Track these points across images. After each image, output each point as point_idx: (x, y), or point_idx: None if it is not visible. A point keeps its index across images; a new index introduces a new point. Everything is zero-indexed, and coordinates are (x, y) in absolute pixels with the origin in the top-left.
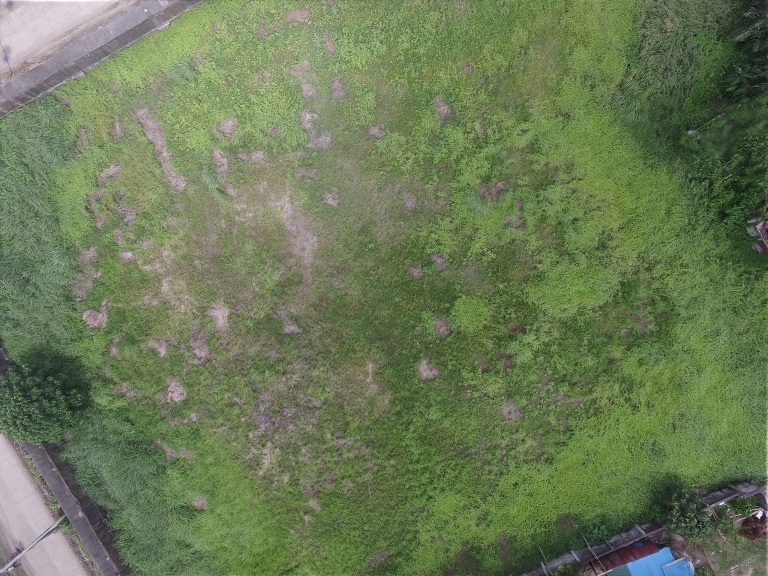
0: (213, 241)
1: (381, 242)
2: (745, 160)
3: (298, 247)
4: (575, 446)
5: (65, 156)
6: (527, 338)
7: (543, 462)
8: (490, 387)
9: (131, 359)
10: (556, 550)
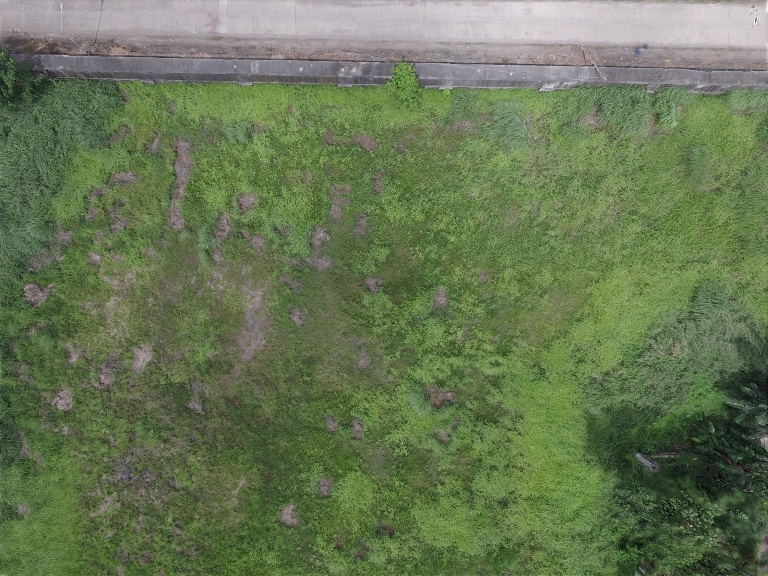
0: (176, 290)
1: (318, 380)
2: (656, 532)
3: (245, 340)
4: None
5: (93, 144)
6: (390, 543)
7: None
8: (333, 565)
9: (43, 348)
10: None
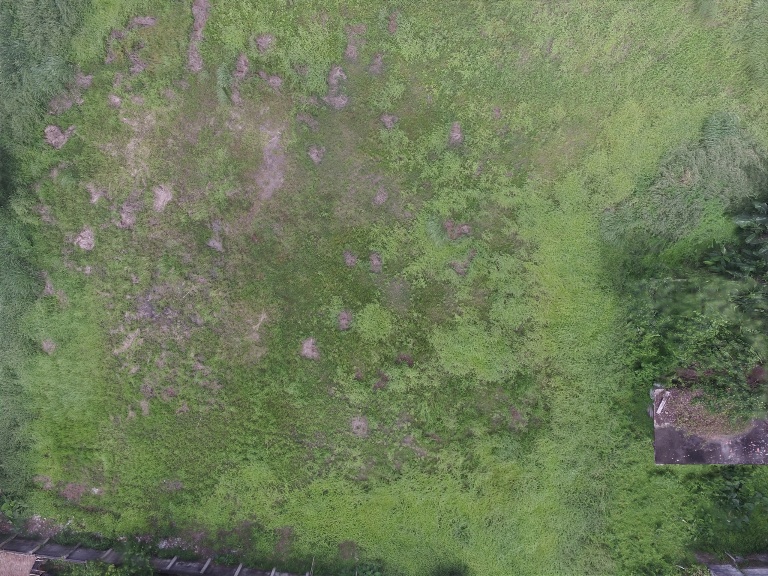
0: (195, 131)
1: (336, 216)
2: (672, 324)
3: (263, 179)
4: (396, 489)
5: None
6: (410, 372)
7: (361, 487)
8: (354, 395)
9: (65, 189)
10: (327, 569)
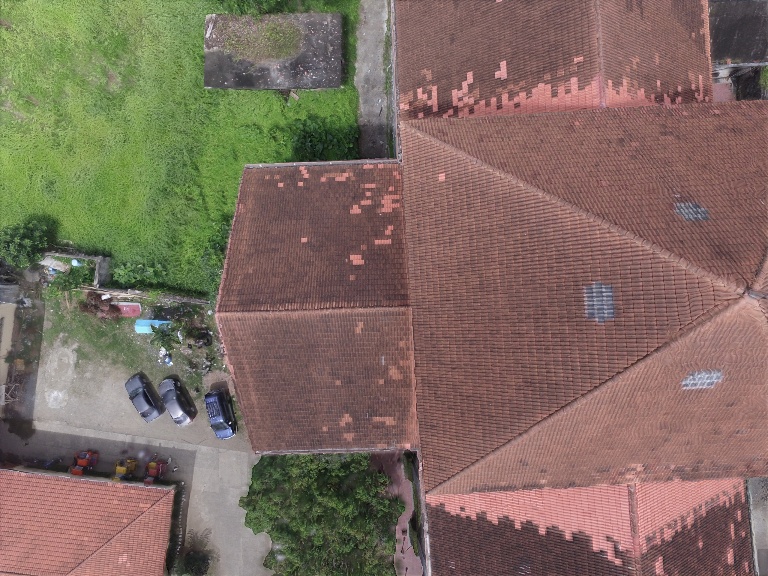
0: None
1: None
2: None
3: None
4: None
5: None
6: (4, 32)
7: None
8: None
9: None
10: None
